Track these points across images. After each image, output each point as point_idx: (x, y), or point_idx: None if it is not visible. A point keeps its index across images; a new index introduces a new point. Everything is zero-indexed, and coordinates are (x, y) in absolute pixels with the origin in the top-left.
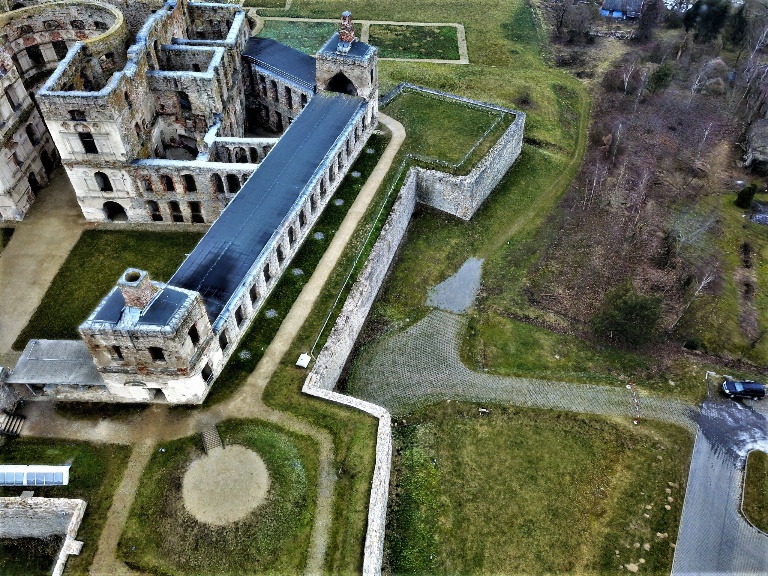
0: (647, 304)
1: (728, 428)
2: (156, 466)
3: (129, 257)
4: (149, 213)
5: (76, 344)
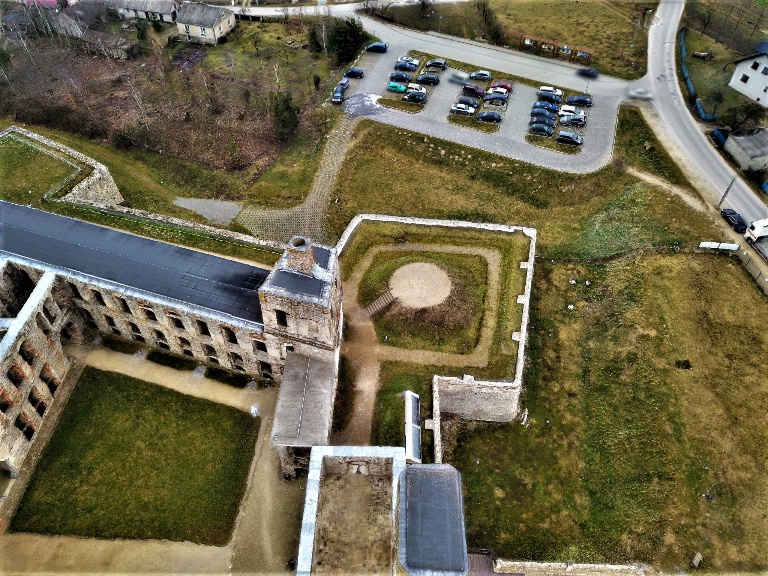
0: (282, 100)
1: (362, 107)
2: (399, 341)
3: (95, 455)
4: (23, 436)
5: (283, 398)
